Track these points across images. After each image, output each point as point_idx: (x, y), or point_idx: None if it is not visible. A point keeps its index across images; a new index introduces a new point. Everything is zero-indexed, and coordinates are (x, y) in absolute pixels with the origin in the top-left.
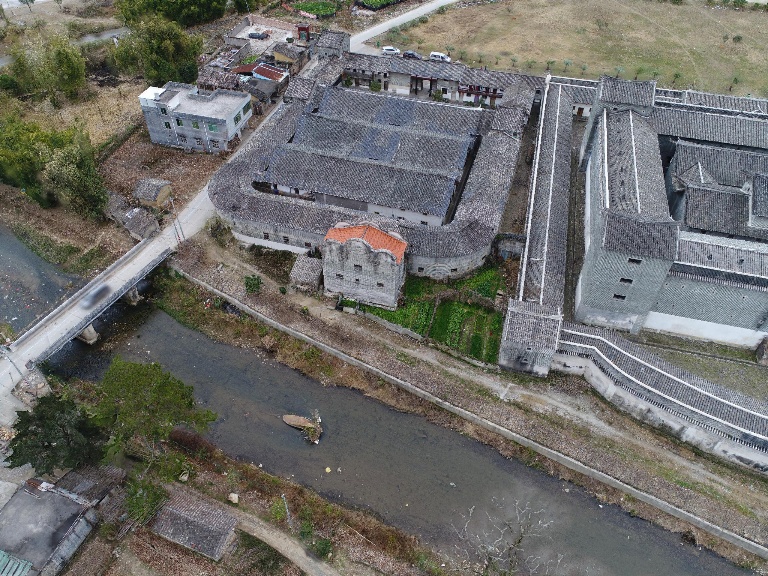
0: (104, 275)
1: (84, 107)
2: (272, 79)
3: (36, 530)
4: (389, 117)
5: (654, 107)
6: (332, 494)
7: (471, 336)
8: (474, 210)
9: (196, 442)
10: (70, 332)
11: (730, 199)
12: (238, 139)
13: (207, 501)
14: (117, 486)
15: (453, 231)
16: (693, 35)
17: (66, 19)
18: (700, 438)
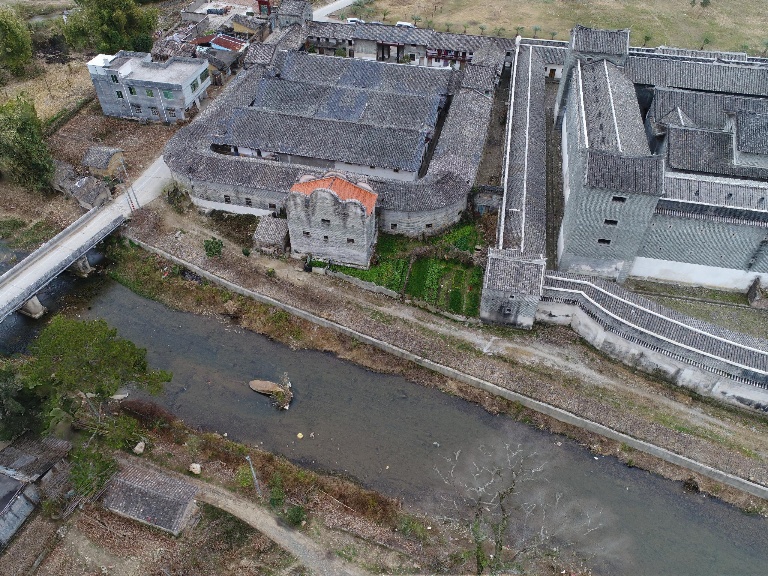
0: (50, 245)
1: (31, 84)
2: (231, 49)
3: None
4: (355, 80)
5: (628, 57)
6: (305, 460)
7: (450, 292)
8: (447, 163)
9: (153, 413)
10: (11, 303)
11: (713, 138)
12: (196, 108)
13: (165, 473)
14: (62, 460)
15: (426, 184)
16: (661, 2)
17: (13, 1)
18: (697, 380)
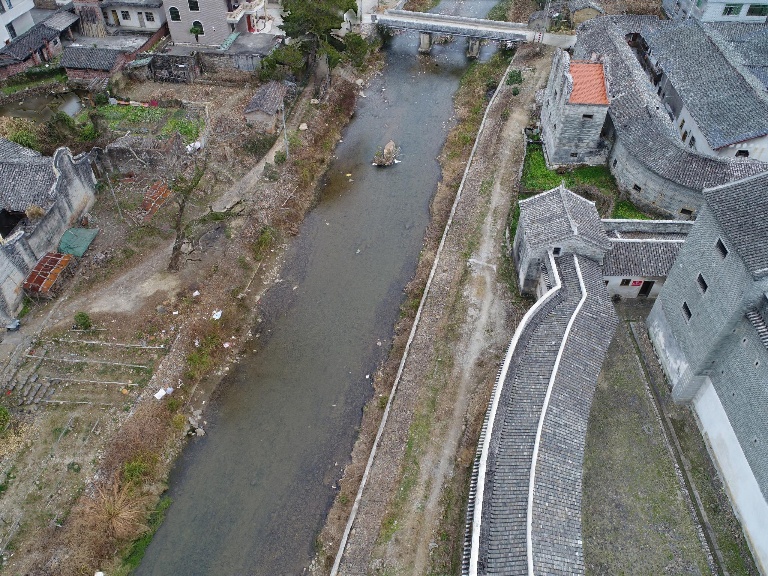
0: (475, 22)
1: None
2: None
3: (249, 45)
4: None
5: None
6: (326, 180)
7: None
8: None
9: (347, 104)
10: (410, 24)
11: None
12: None
13: (298, 117)
14: None
15: None
16: None
17: None
18: None
